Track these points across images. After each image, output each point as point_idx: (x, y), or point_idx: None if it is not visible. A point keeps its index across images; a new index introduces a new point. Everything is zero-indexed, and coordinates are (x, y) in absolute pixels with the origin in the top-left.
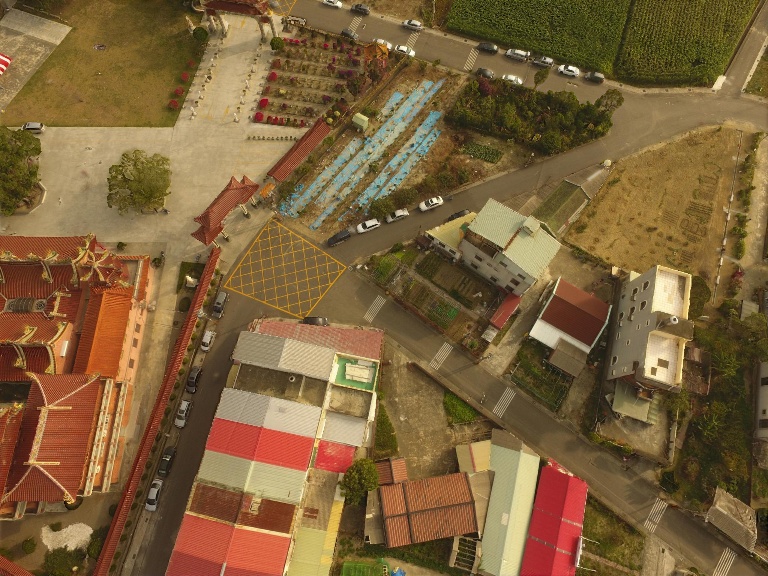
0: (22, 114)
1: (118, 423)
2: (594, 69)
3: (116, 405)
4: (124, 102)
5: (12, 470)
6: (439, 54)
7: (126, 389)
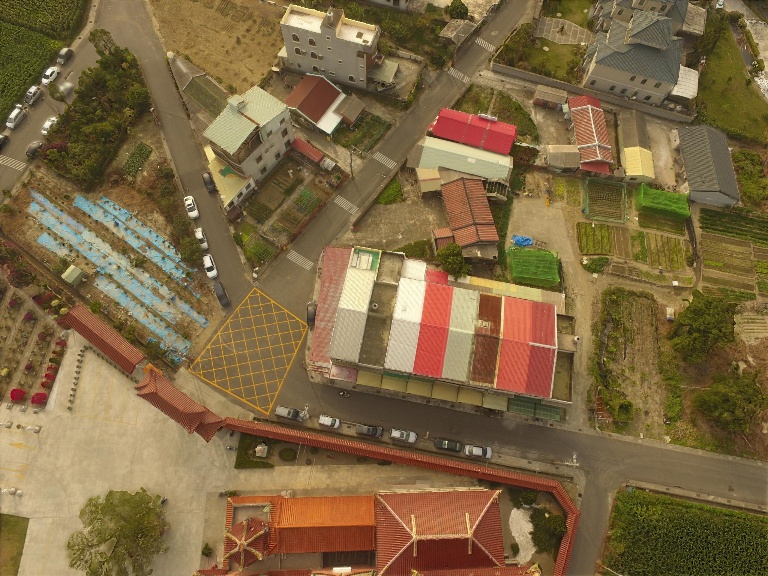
0: None
1: None
2: (54, 55)
3: None
4: None
5: None
6: None
7: None
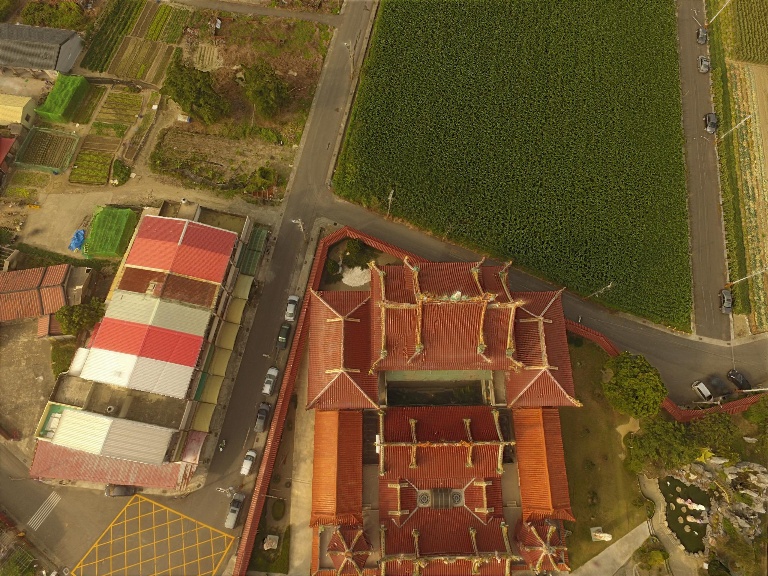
0: None
1: None
2: None
3: None
4: None
5: None
6: None
7: None
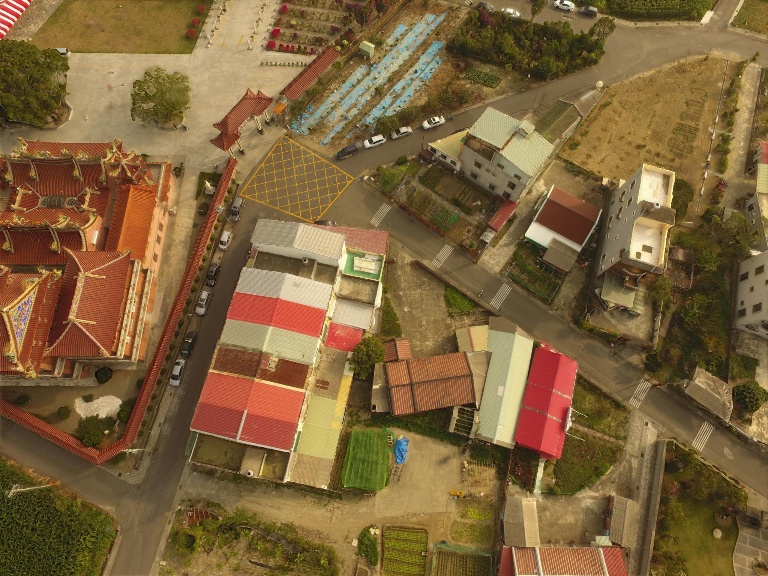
0: (48, 42)
1: (145, 304)
2: (588, 4)
3: (143, 288)
4: (144, 32)
5: (52, 330)
6: None
7: (151, 276)
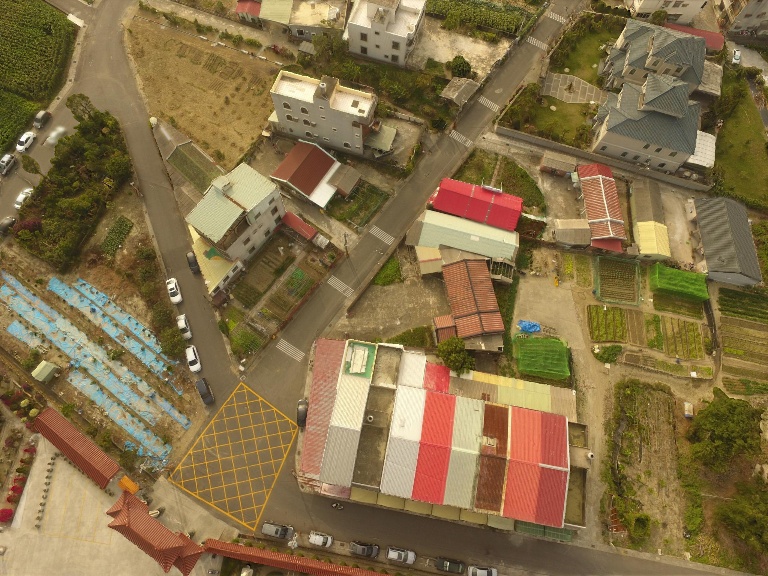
0: None
1: None
2: (30, 118)
3: None
4: None
5: None
6: None
7: None
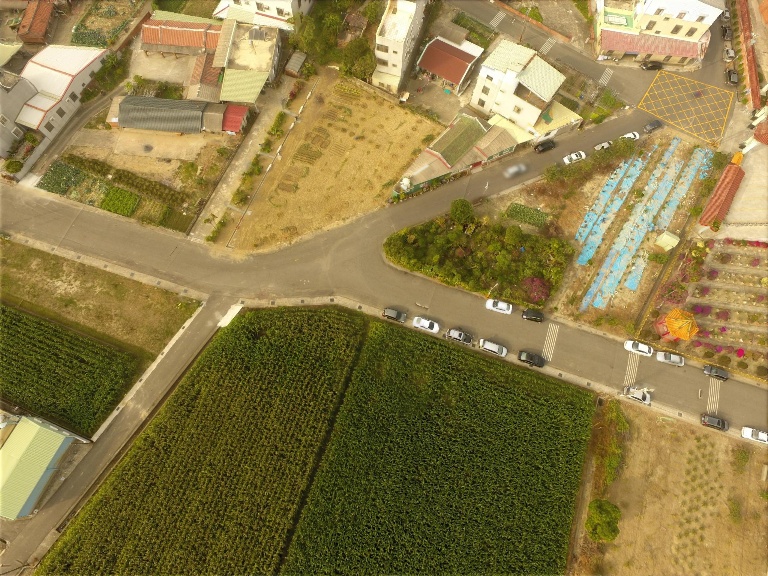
0: None
1: None
2: None
3: None
4: None
5: None
6: (593, 349)
7: None
